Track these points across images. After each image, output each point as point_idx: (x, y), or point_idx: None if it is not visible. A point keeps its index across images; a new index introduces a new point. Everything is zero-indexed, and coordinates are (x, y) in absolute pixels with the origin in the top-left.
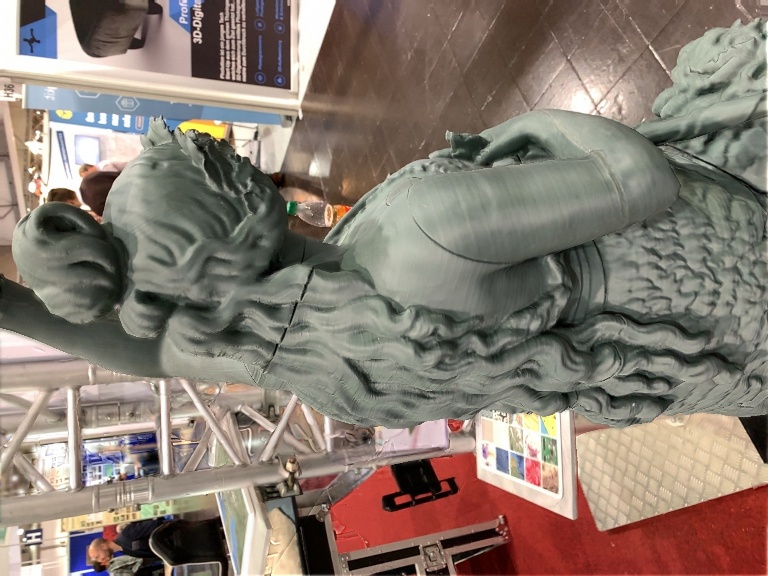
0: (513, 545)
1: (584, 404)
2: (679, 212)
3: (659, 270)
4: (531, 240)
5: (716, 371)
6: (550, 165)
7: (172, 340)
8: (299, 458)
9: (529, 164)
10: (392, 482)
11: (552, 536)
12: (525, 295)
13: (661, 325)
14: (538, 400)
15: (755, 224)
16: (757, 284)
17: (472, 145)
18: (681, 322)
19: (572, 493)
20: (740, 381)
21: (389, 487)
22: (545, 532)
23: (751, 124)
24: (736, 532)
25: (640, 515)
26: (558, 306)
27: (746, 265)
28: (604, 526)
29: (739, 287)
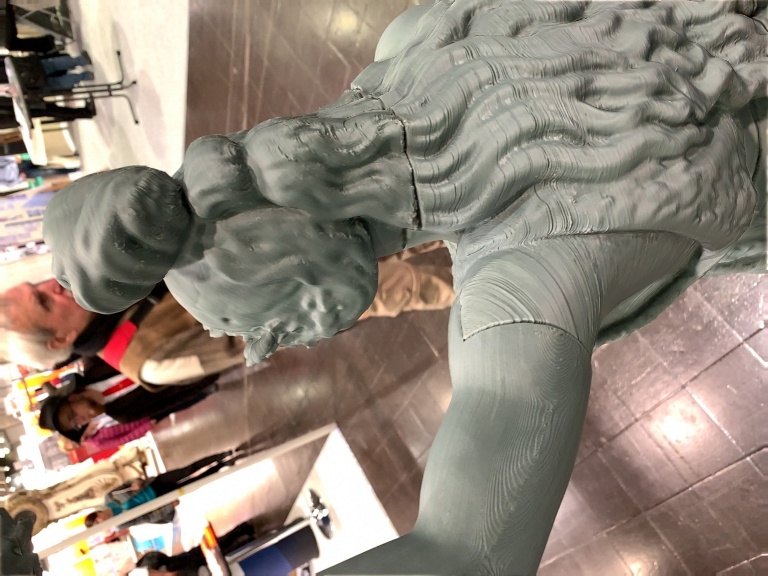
0: None
1: None
2: None
3: None
4: None
5: None
6: None
7: (259, 149)
8: None
9: None
10: None
11: None
12: None
13: None
14: None
15: None
16: None
17: None
18: None
19: None
20: None
21: None
22: None
23: None
24: None
25: None
26: None
27: None
28: None
29: None
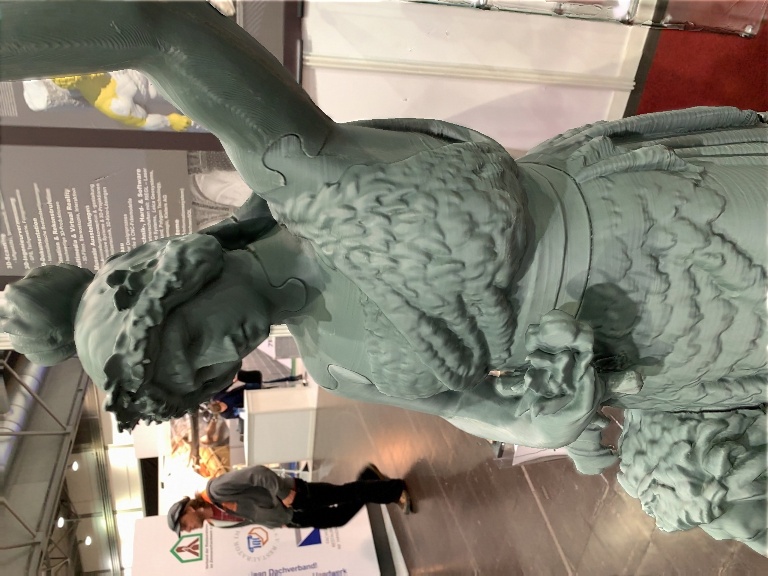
0: None
1: None
2: None
3: None
4: None
5: None
6: None
7: None
8: None
9: None
10: None
11: None
12: None
13: None
14: None
15: None
16: None
17: None
18: None
19: None
20: None
21: None
22: None
23: None
24: None
25: None
26: None
27: None
28: None
29: None
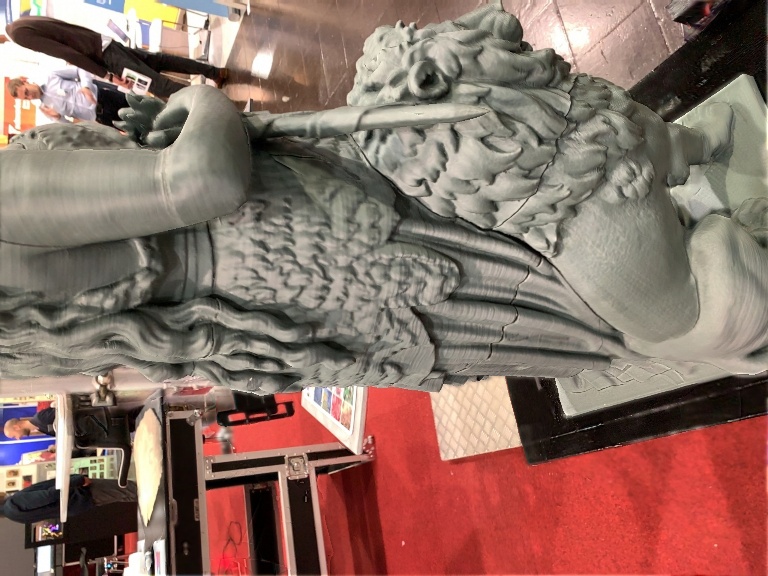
0: (376, 463)
1: (200, 374)
2: (297, 209)
3: (264, 262)
4: (72, 229)
5: (314, 359)
6: (111, 156)
7: None
8: (117, 372)
9: (101, 151)
10: (231, 400)
11: (407, 459)
12: (104, 274)
13: (255, 314)
14: (148, 367)
15: (380, 227)
16: (372, 284)
17: (148, 109)
18: (286, 312)
19: (359, 431)
20: (370, 366)
21: (226, 404)
22: (403, 455)
23: (390, 130)
24: (544, 475)
25: (474, 451)
26: (140, 288)
27: (363, 265)
28: (446, 456)
29: (352, 285)
